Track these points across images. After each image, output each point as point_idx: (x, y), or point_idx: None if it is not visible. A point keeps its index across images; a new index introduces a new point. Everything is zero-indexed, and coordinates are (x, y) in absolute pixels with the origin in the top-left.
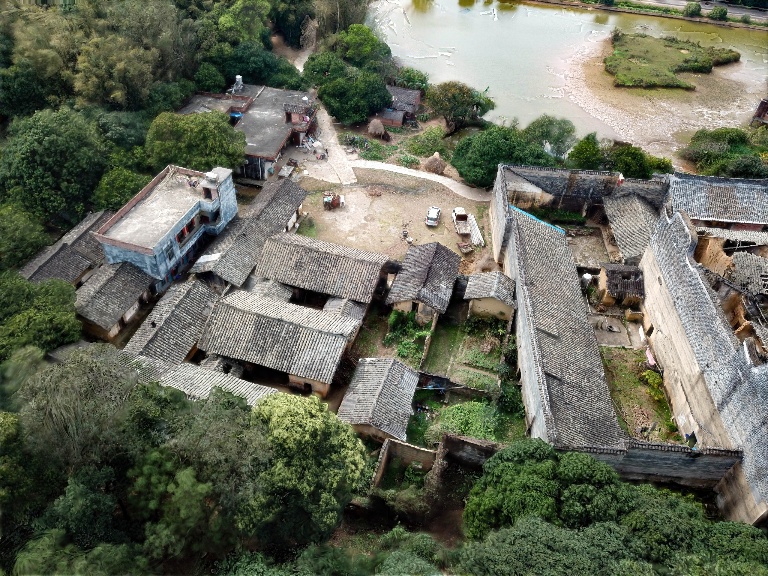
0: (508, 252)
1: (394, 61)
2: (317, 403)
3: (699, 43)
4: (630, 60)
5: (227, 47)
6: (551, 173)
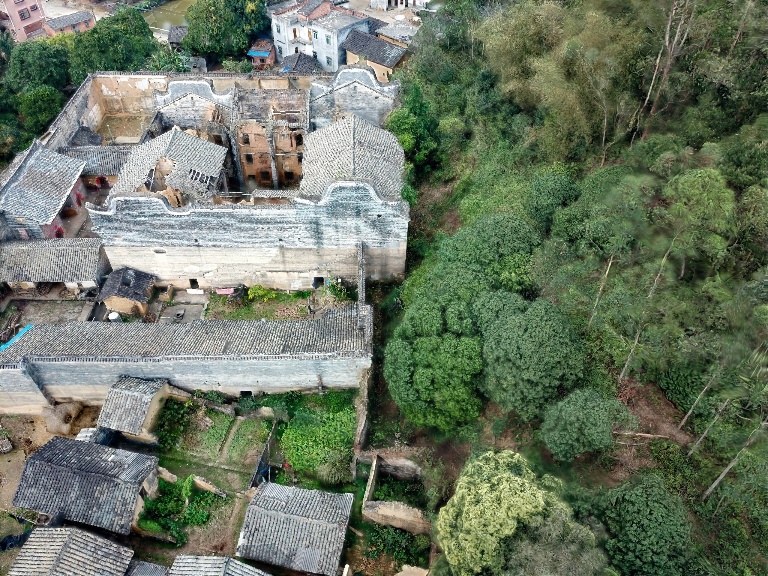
0: (57, 384)
1: None
2: (466, 490)
3: None
4: None
5: None
6: None
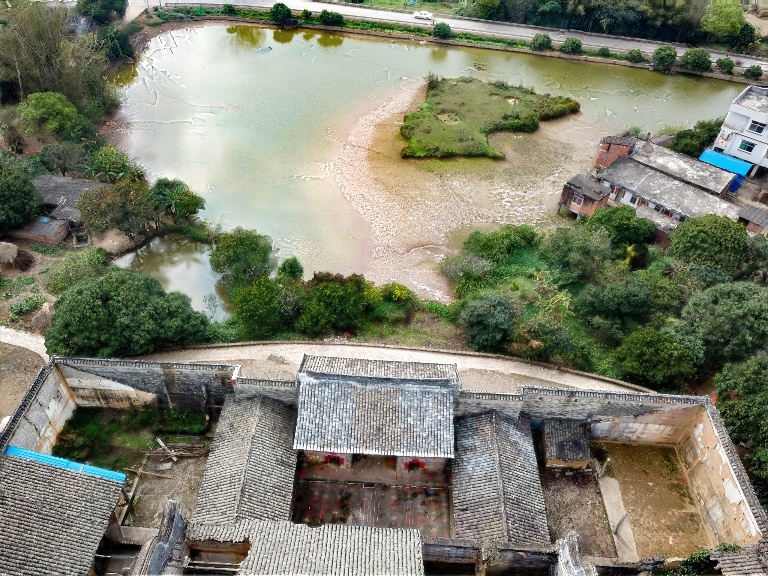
0: None
1: (95, 139)
2: None
3: (534, 89)
4: (438, 116)
5: None
6: (133, 368)
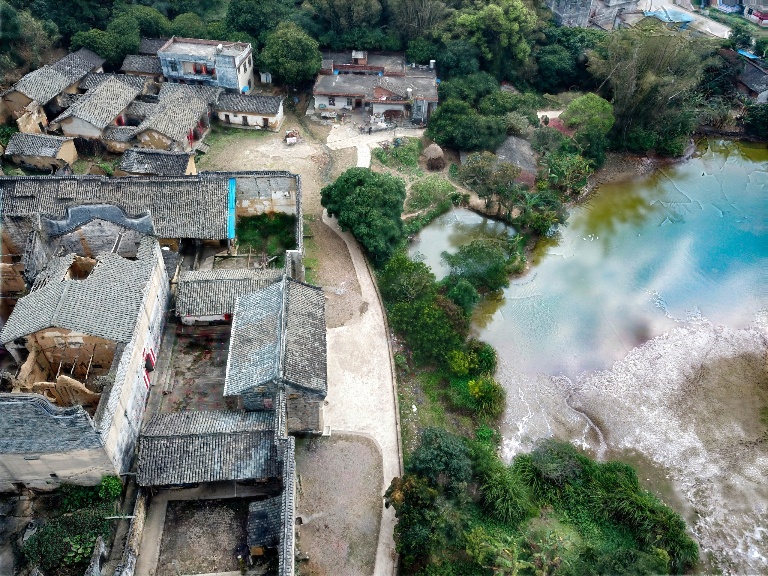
0: None
1: None
2: None
3: None
4: None
5: (446, 36)
6: None
